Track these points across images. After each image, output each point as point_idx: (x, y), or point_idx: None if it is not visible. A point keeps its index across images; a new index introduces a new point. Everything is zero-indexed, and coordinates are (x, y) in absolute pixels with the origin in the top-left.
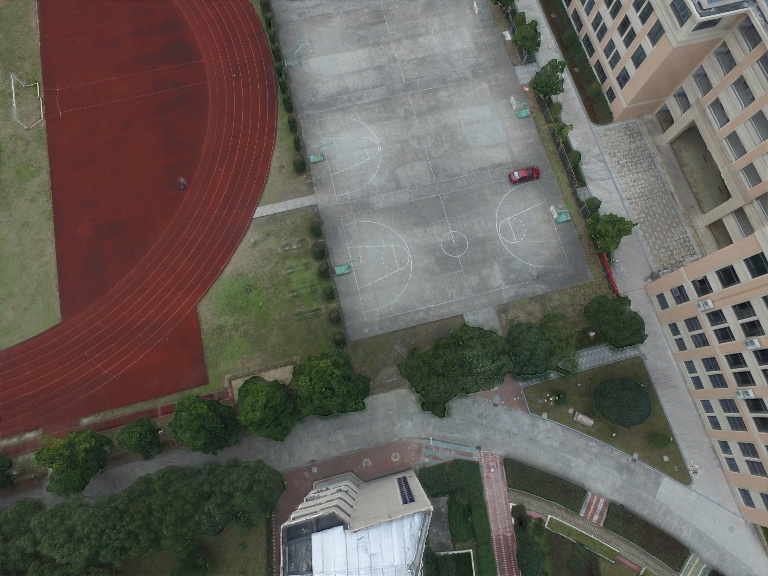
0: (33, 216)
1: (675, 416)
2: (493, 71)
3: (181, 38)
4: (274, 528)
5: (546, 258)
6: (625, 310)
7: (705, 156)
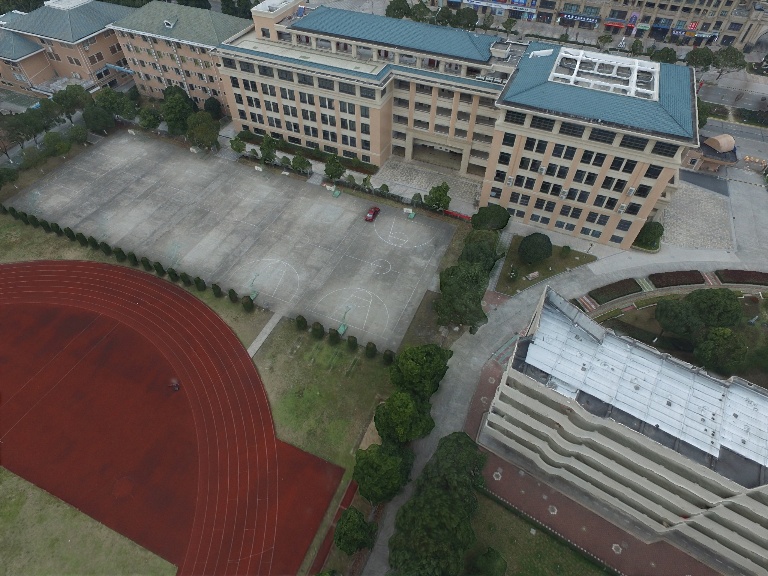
0: (55, 529)
1: (556, 242)
2: (298, 190)
3: (66, 316)
4: (492, 493)
5: (428, 236)
6: (489, 207)
7: (431, 153)
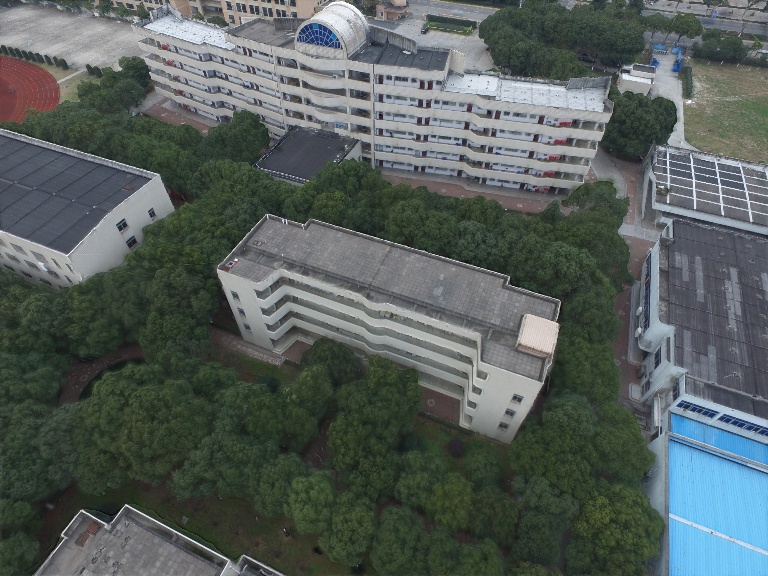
0: None
1: None
2: (122, 28)
3: None
4: None
5: None
6: None
7: (218, 13)
